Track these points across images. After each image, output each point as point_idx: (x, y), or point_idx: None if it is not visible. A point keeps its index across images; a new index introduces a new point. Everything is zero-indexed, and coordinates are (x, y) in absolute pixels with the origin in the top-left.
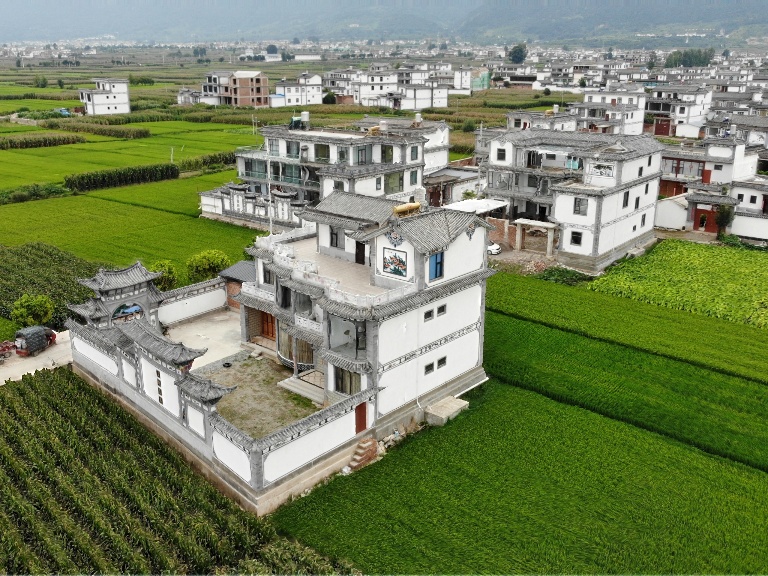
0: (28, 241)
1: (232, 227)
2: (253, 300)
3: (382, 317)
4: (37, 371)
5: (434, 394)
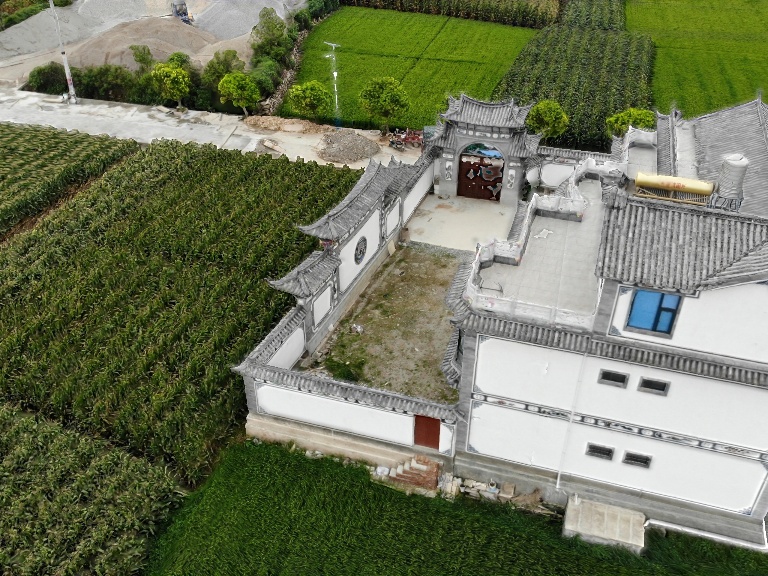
0: (657, 30)
1: None
2: None
3: None
4: None
5: (605, 489)
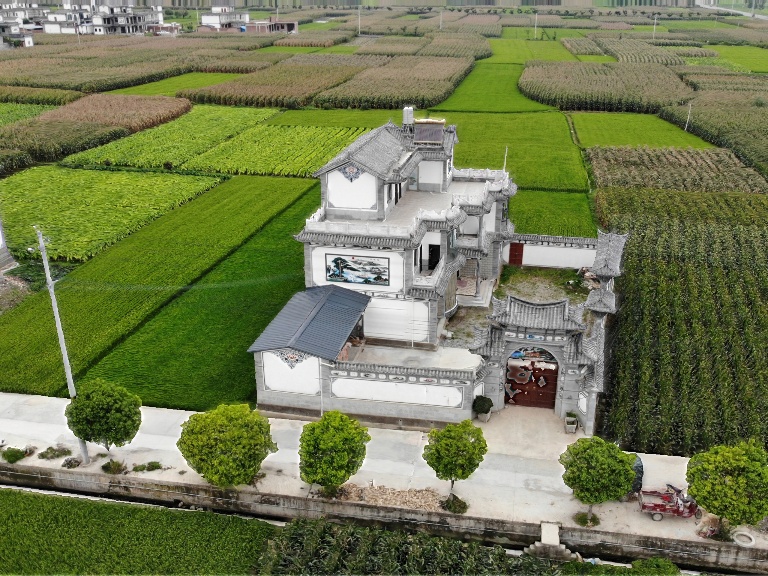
0: None
1: None
2: (443, 281)
3: None
4: (650, 427)
5: None
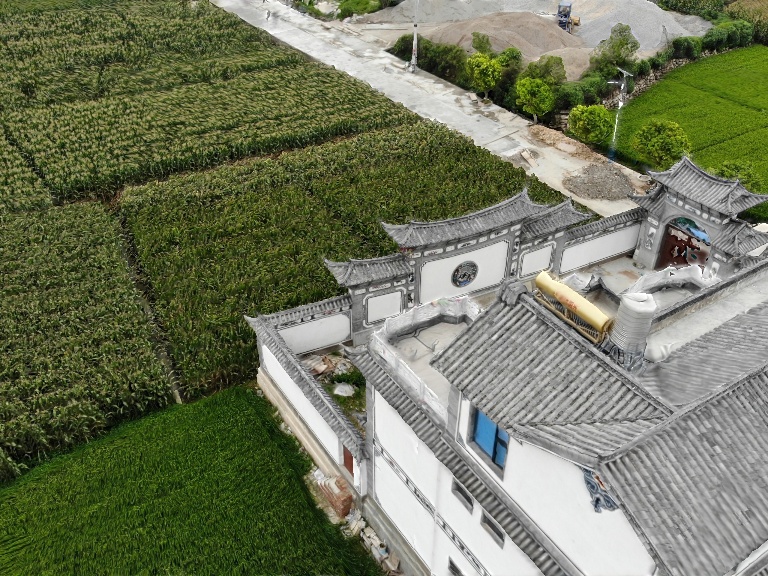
0: None
1: None
2: None
3: None
4: None
5: None
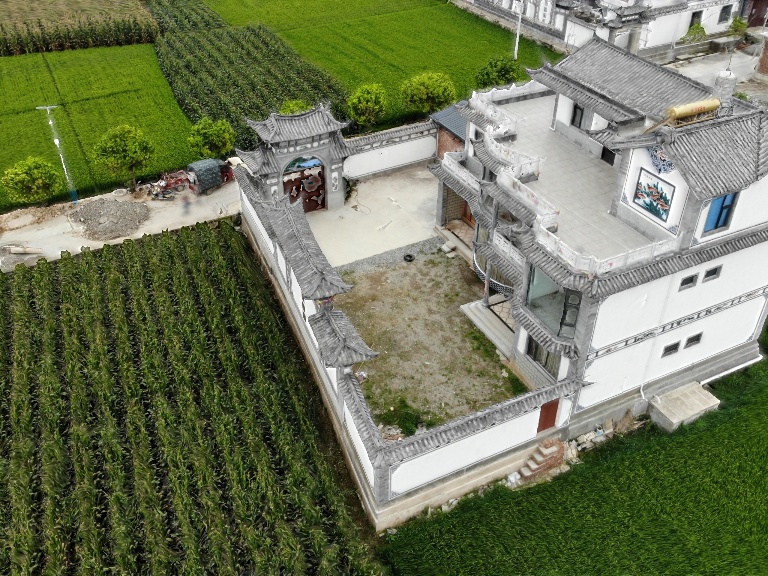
0: (255, 18)
1: (481, 23)
2: (454, 180)
3: (608, 293)
4: (198, 224)
5: (670, 379)
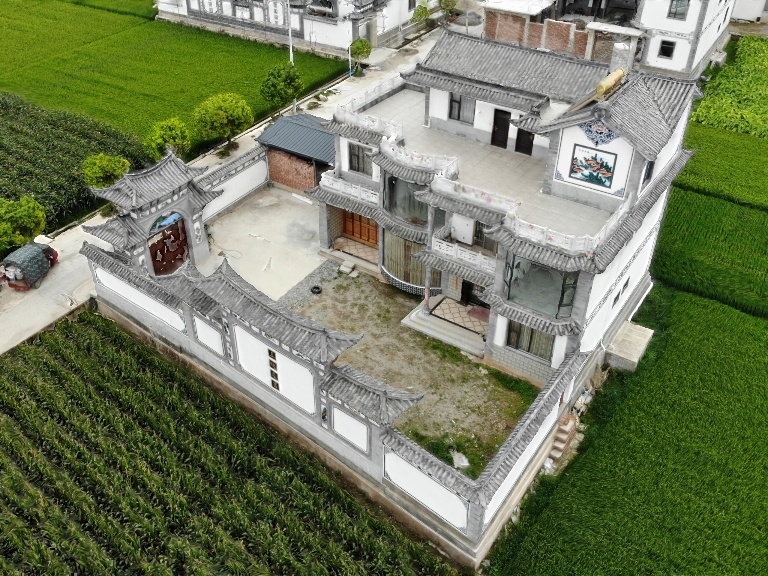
0: None
1: (207, 35)
2: (343, 199)
3: None
4: (58, 324)
5: (613, 325)
